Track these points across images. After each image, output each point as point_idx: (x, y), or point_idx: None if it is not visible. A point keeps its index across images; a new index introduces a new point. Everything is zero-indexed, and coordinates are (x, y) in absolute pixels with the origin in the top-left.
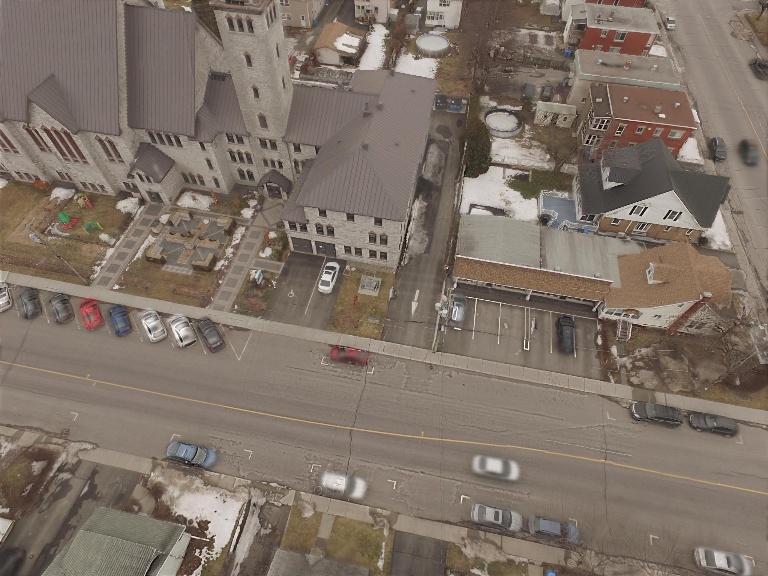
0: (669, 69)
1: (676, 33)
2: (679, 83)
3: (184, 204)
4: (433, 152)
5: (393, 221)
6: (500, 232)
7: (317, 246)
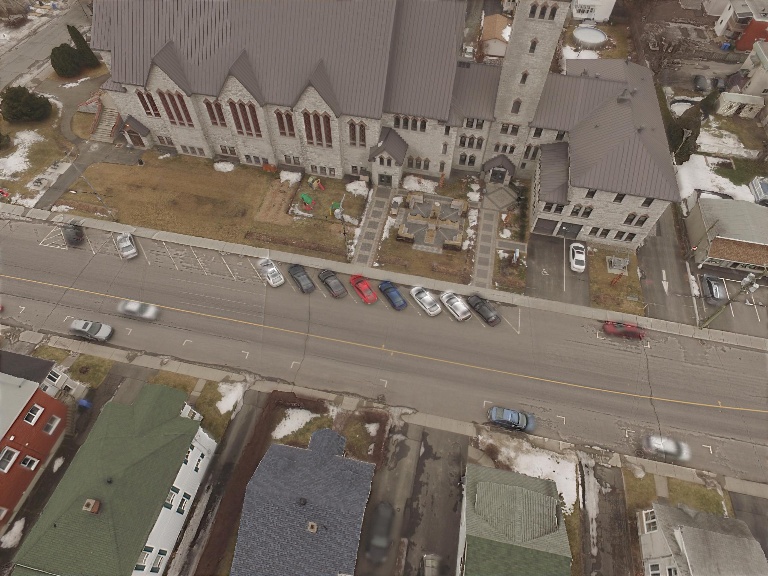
0: None
1: None
2: None
3: (411, 187)
4: None
5: (665, 202)
6: (746, 215)
7: (561, 227)
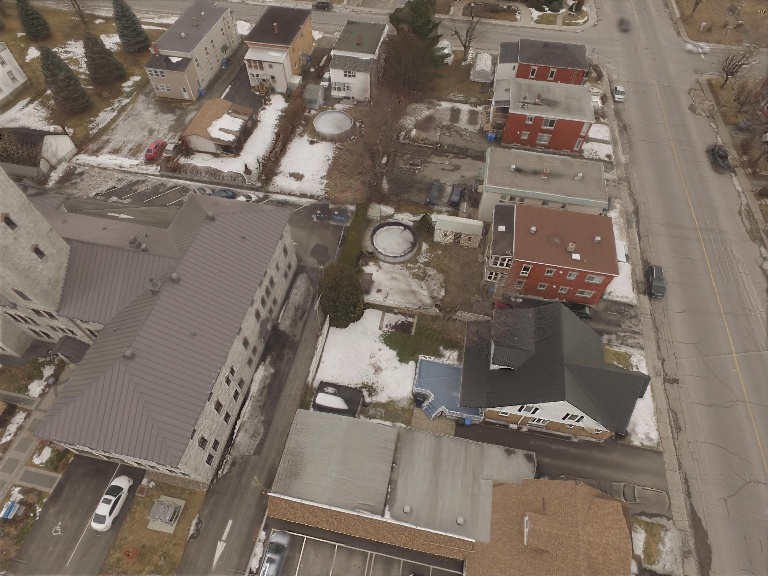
0: (597, 178)
1: (625, 106)
2: (607, 200)
3: None
4: (300, 286)
5: None
6: (338, 446)
7: None
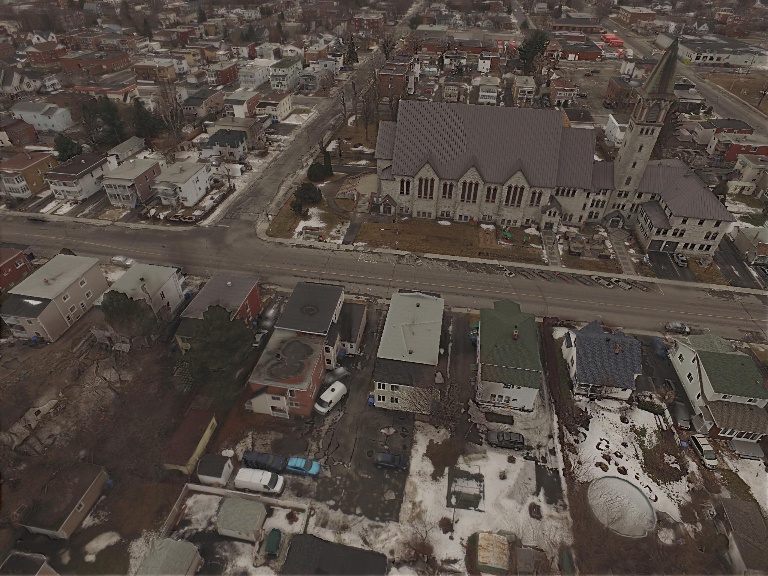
0: None
1: None
2: None
3: (564, 230)
4: None
5: (728, 223)
6: None
7: (665, 245)
